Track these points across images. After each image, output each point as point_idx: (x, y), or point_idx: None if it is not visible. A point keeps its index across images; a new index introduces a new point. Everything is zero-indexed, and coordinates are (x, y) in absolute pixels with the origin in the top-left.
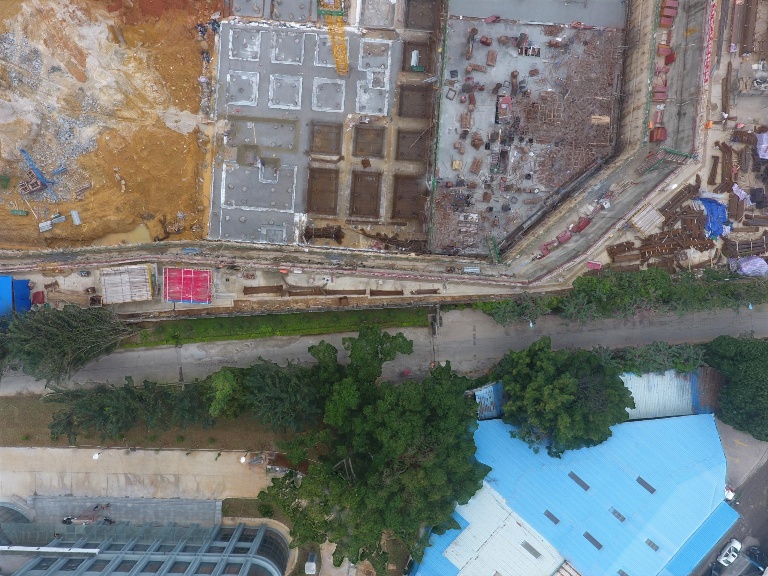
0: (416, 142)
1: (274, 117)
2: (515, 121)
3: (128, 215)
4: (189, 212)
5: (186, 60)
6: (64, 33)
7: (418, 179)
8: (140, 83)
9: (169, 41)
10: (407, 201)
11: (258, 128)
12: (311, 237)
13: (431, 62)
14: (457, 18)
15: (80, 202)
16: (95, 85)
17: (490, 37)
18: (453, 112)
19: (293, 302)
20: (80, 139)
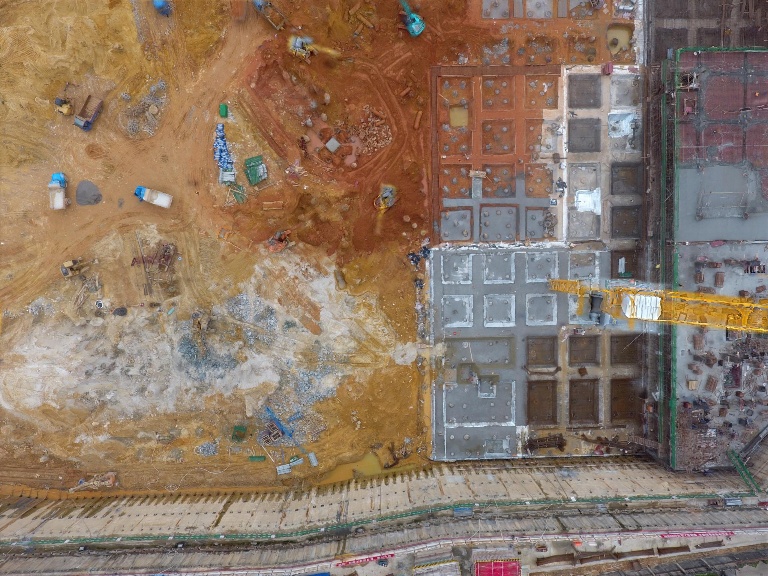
0: (629, 346)
1: (490, 336)
2: (747, 338)
3: (361, 449)
4: (415, 436)
5: (405, 293)
6: (297, 290)
7: (632, 380)
8: (371, 328)
9: (385, 275)
10: (622, 402)
11: (474, 346)
12: (535, 448)
13: (638, 267)
14: (683, 244)
15: (316, 443)
16: (330, 336)
17: (716, 259)
18: (685, 334)
19: (586, 569)
20: (319, 389)
